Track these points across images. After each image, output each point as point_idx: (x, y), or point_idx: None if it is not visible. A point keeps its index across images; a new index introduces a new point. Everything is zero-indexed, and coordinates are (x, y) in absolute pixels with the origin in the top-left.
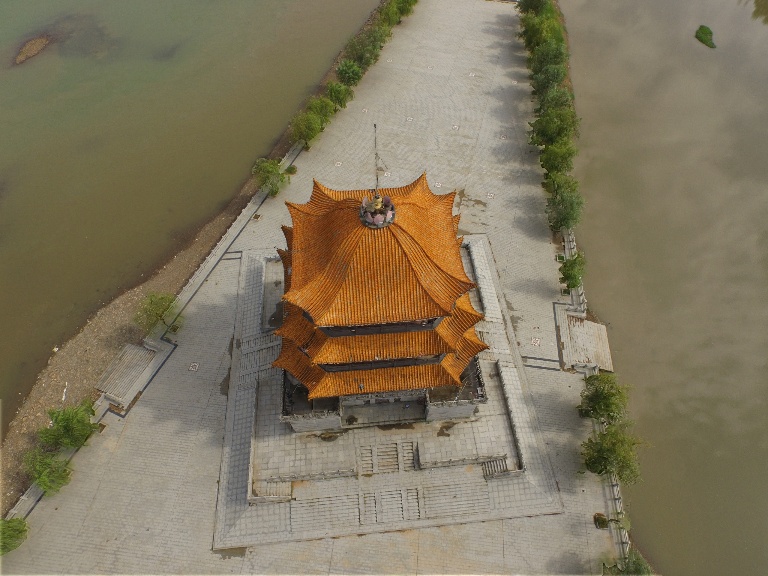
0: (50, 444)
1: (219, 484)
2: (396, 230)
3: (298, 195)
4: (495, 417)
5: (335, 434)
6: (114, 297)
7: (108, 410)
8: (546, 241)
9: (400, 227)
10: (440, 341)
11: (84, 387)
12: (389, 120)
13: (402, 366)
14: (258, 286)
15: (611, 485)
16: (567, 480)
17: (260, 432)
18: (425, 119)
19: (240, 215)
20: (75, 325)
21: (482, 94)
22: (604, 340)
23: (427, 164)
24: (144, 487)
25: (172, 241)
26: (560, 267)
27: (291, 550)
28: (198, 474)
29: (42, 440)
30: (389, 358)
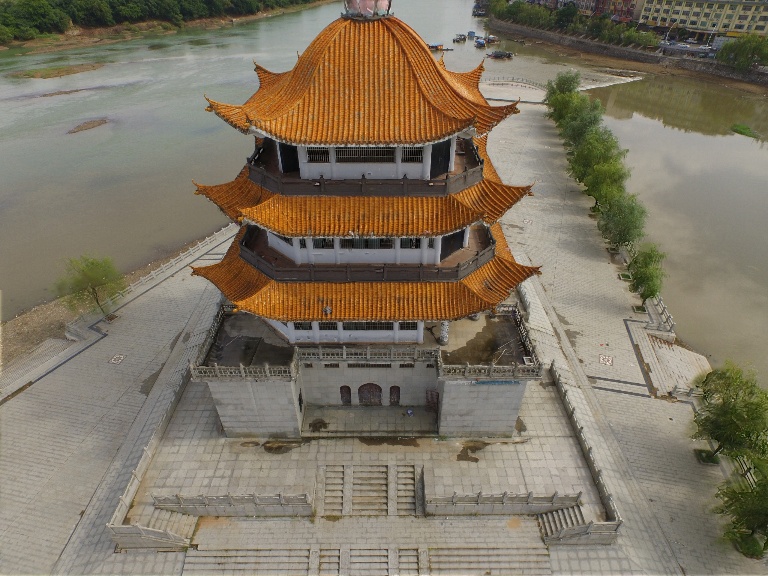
0: None
1: (82, 516)
2: (392, 26)
3: None
4: (554, 439)
5: (288, 444)
6: (61, 296)
7: None
8: (603, 261)
9: (399, 24)
10: (458, 209)
11: None
12: None
13: (397, 281)
14: None
15: None
16: (701, 566)
17: (171, 432)
18: None
19: (233, 223)
20: None
21: (513, 153)
22: None
23: None
24: None
25: (152, 252)
26: None
27: None
28: (56, 498)
29: None
30: (372, 234)
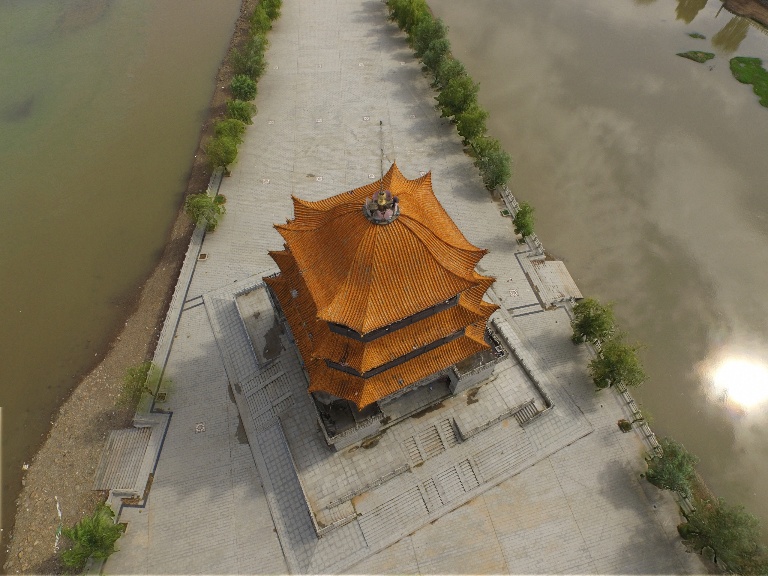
0: (65, 568)
1: (277, 532)
2: (405, 220)
3: (237, 223)
4: (510, 370)
5: (375, 439)
6: (72, 388)
7: (122, 506)
8: (487, 201)
9: (407, 216)
10: (466, 313)
11: (80, 494)
12: (299, 126)
13: (432, 349)
14: (235, 325)
15: (620, 393)
16: (586, 402)
17: (301, 465)
18: (334, 117)
19: (185, 260)
20: (38, 433)
21: (378, 81)
22: (566, 273)
23: (353, 159)
24: (198, 567)
25: (115, 309)
26: (514, 220)
27: (375, 563)
28: (251, 531)
29: (69, 564)
30: (426, 344)
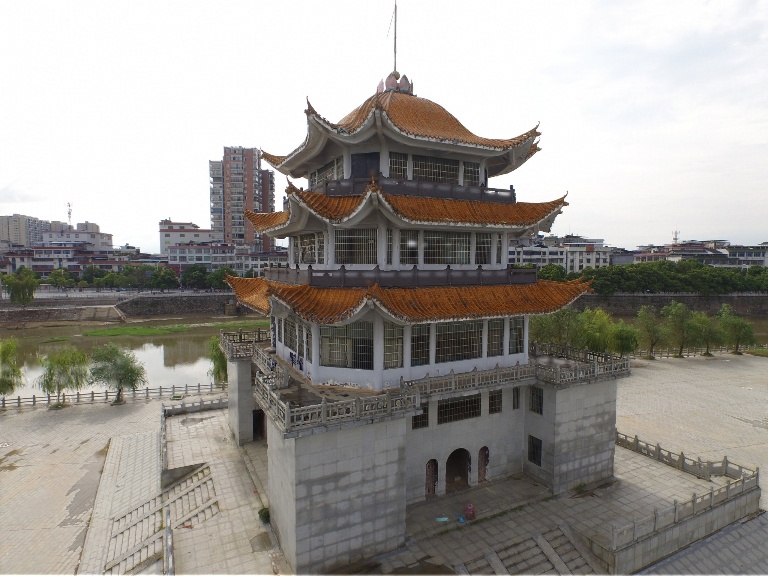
0: None
1: None
2: None
3: None
4: None
5: None
6: None
7: None
8: (142, 406)
9: None
10: None
11: None
12: None
13: None
14: None
15: None
16: None
17: None
18: None
19: None
20: None
21: None
22: None
23: None
24: None
25: None
26: None
27: None
28: None
29: None
30: None
